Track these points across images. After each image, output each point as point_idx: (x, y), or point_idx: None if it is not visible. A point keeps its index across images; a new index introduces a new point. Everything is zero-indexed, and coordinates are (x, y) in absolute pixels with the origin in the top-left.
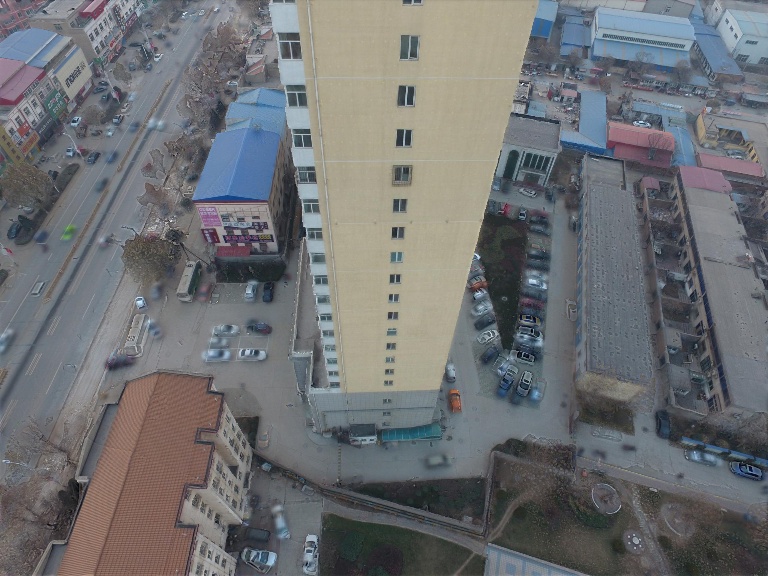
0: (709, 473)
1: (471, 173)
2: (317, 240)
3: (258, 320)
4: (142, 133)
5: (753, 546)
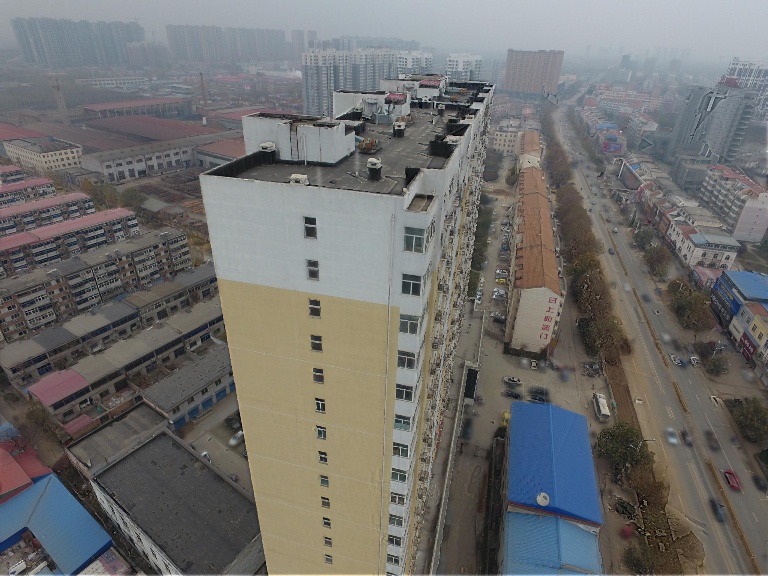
0: None
1: None
2: None
3: None
4: None
5: None
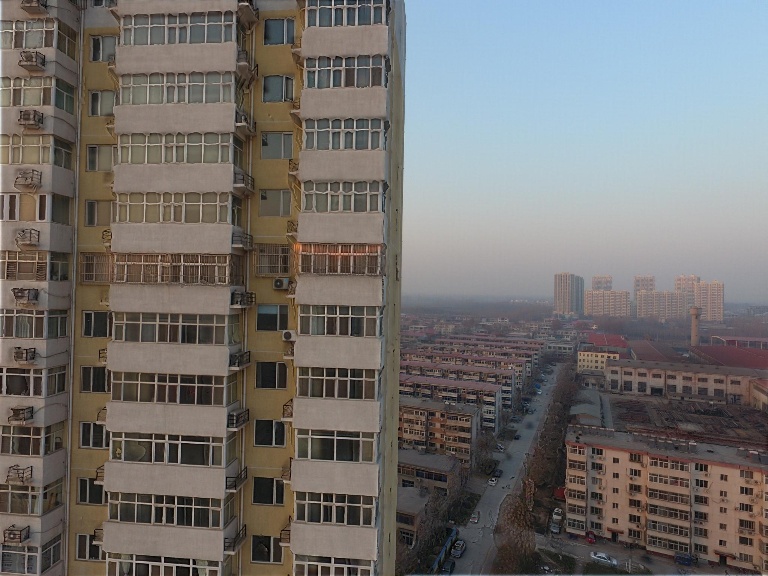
0: (460, 571)
1: (400, 270)
2: (380, 397)
3: None
4: None
5: (525, 559)
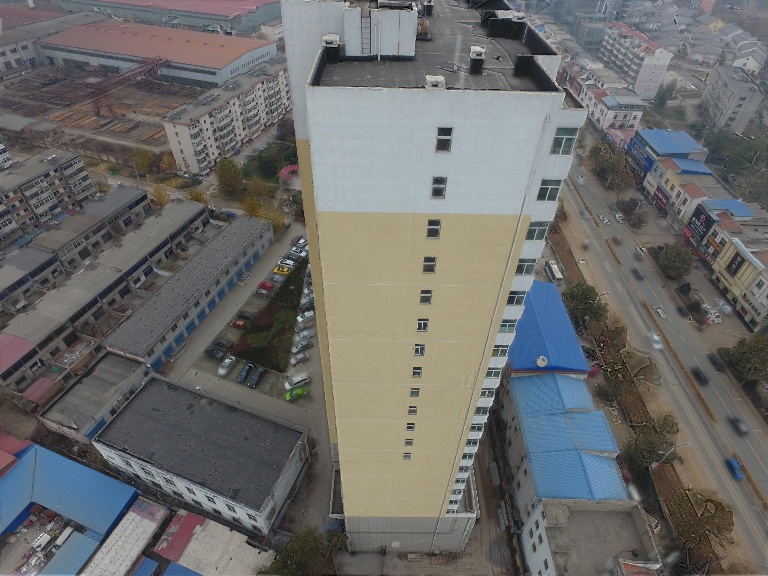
0: None
1: None
2: None
3: None
4: None
5: None
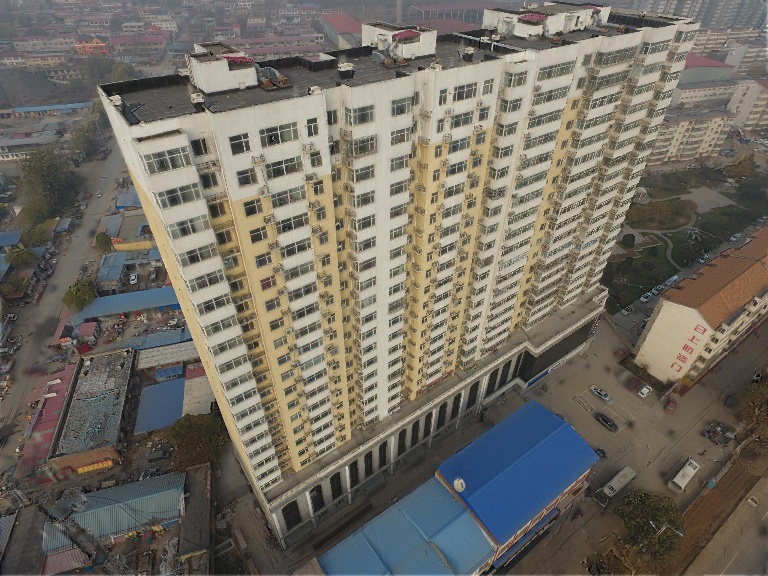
0: None
1: None
2: None
3: (578, 412)
4: None
5: None
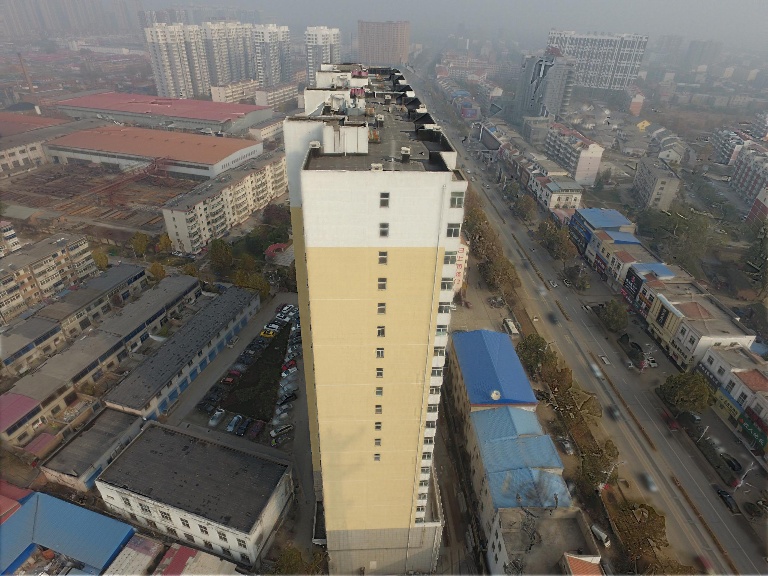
0: None
1: None
2: None
3: None
4: (729, 567)
5: None
